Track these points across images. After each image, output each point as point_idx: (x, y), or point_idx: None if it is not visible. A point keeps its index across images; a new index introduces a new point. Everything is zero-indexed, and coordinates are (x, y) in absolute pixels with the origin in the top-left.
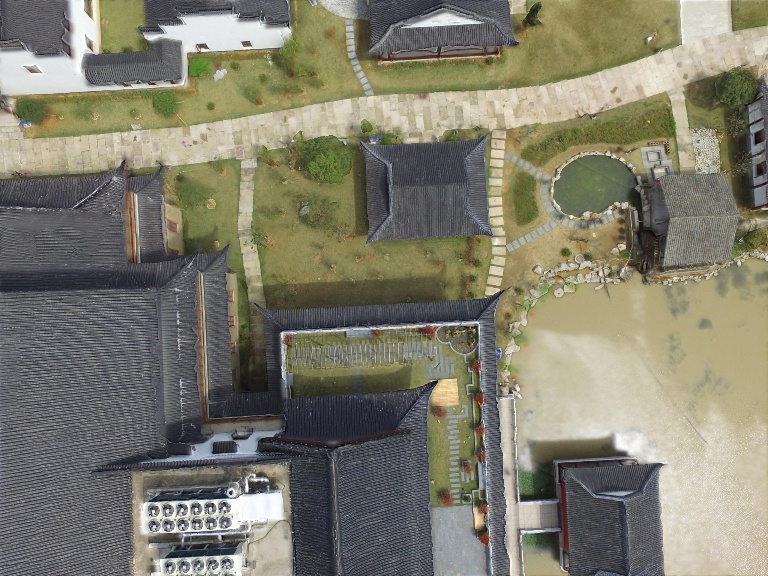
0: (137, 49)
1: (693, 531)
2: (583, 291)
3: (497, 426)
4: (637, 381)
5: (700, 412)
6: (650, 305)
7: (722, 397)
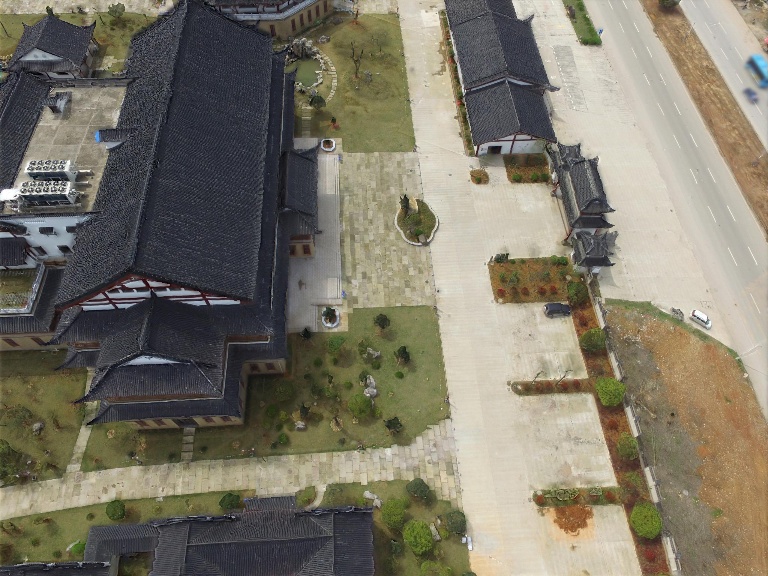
0: (143, 573)
1: None
2: None
3: None
4: None
5: None
6: None
7: None
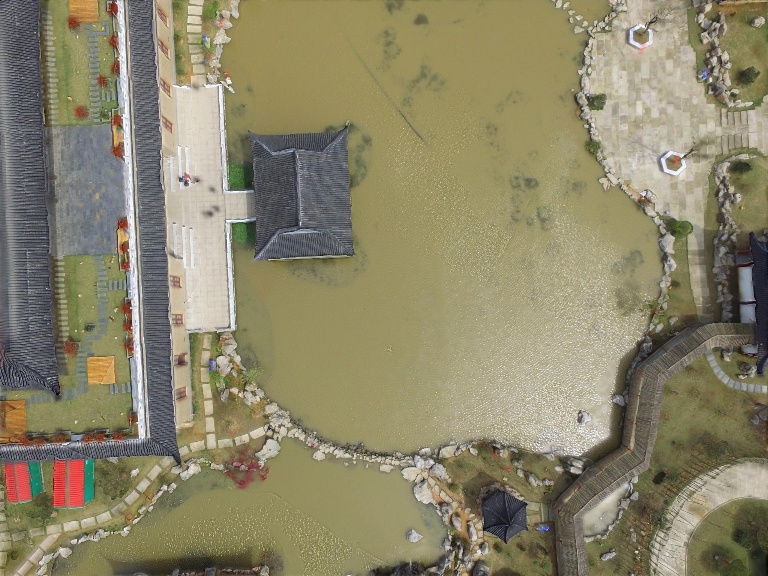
0: None
1: (408, 228)
2: (313, 3)
3: (151, 57)
4: (353, 78)
5: (415, 107)
6: (367, 2)
7: (437, 92)
